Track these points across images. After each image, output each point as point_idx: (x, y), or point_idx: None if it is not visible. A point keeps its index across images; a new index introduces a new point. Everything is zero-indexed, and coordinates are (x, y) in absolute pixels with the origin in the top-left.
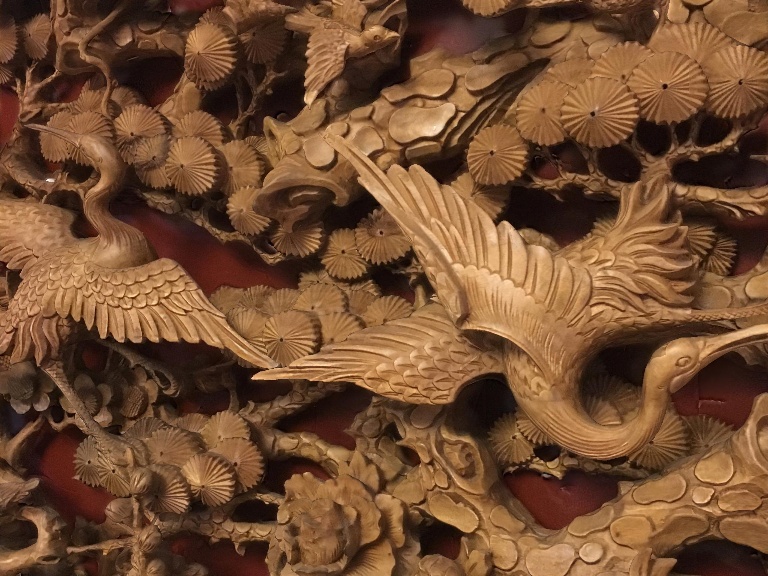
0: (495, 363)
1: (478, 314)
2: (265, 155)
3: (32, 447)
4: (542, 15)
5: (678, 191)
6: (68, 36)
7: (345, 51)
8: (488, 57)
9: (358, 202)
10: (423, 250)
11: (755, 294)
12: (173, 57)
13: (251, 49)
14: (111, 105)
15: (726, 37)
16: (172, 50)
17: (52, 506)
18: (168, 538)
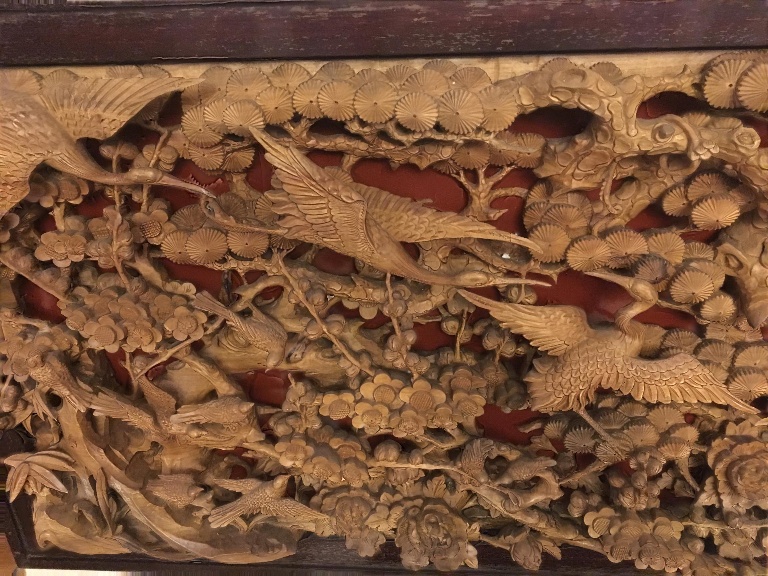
0: None
1: None
2: None
3: None
4: None
5: None
6: (579, 181)
7: None
8: None
9: None
10: None
11: None
12: None
13: None
14: None
15: None
16: (636, 177)
17: None
18: (614, 466)
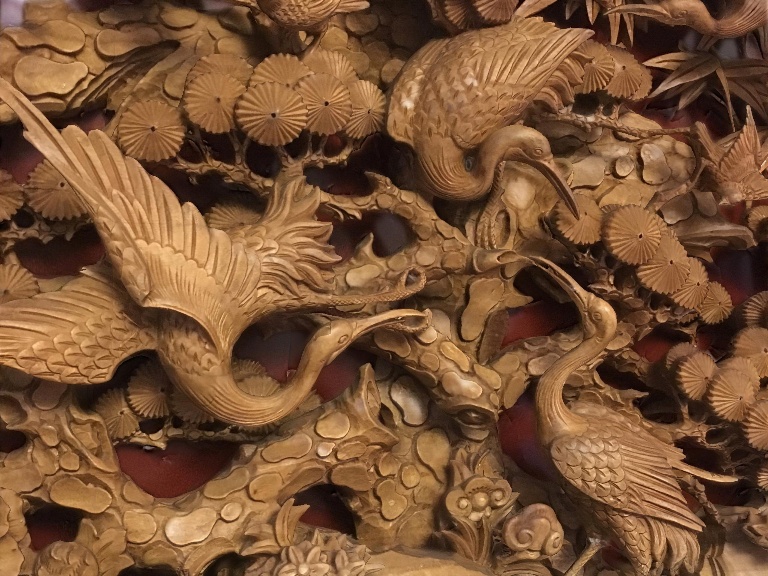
0: (150, 340)
1: (161, 292)
2: None
3: None
4: None
5: None
6: None
7: None
8: (118, 23)
9: None
10: (108, 222)
11: (354, 283)
12: None
13: None
14: None
15: (354, 70)
16: None
17: None
18: None
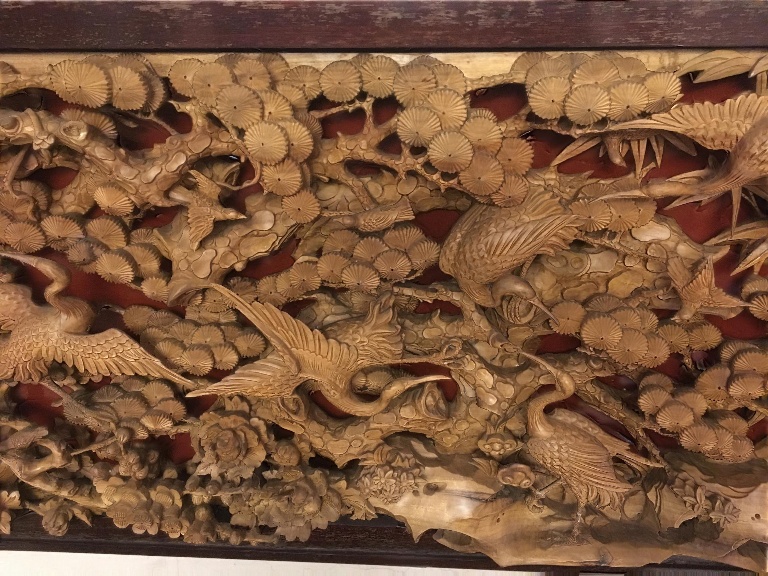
0: None
1: (305, 370)
2: (155, 246)
3: (13, 387)
4: None
5: (395, 290)
6: None
7: (213, 221)
8: None
9: None
10: (276, 345)
11: (427, 337)
12: None
13: None
14: None
15: (420, 232)
16: None
17: (38, 416)
18: None
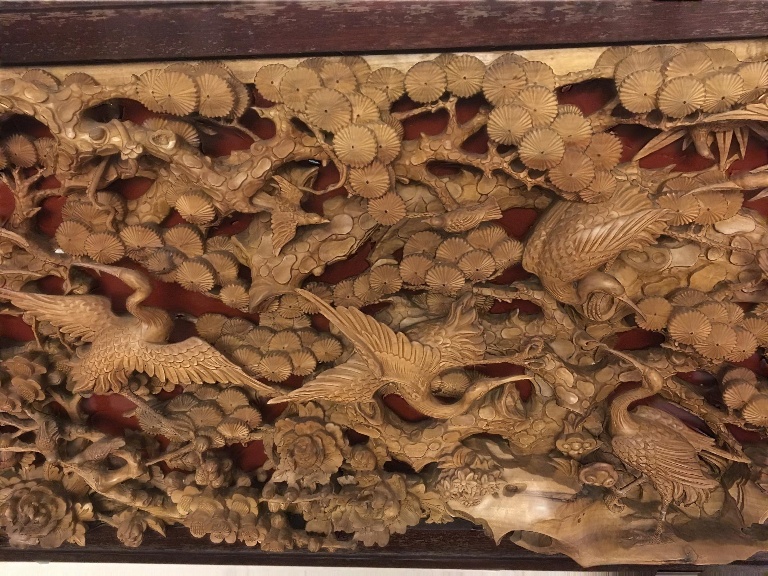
0: None
1: (388, 373)
2: (232, 253)
3: (84, 399)
4: None
5: (474, 291)
6: (70, 180)
7: (296, 226)
8: None
9: None
10: (360, 348)
11: (506, 337)
12: None
13: None
14: (107, 214)
15: (503, 231)
16: None
17: (108, 427)
18: None
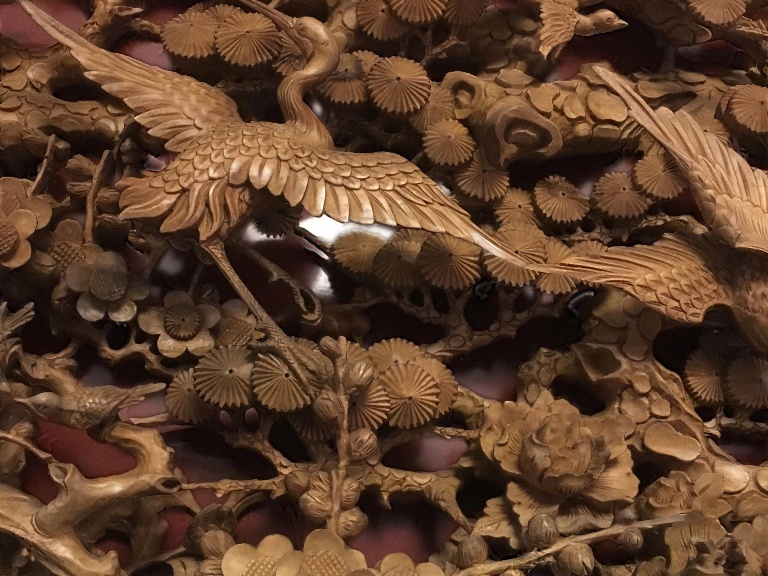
0: (727, 296)
1: (748, 237)
2: None
3: None
4: (678, 65)
5: None
6: None
7: (576, 24)
8: (649, 79)
9: (537, 165)
10: (701, 175)
11: None
12: (315, 8)
13: (452, 8)
14: None
15: None
16: None
17: None
18: None
